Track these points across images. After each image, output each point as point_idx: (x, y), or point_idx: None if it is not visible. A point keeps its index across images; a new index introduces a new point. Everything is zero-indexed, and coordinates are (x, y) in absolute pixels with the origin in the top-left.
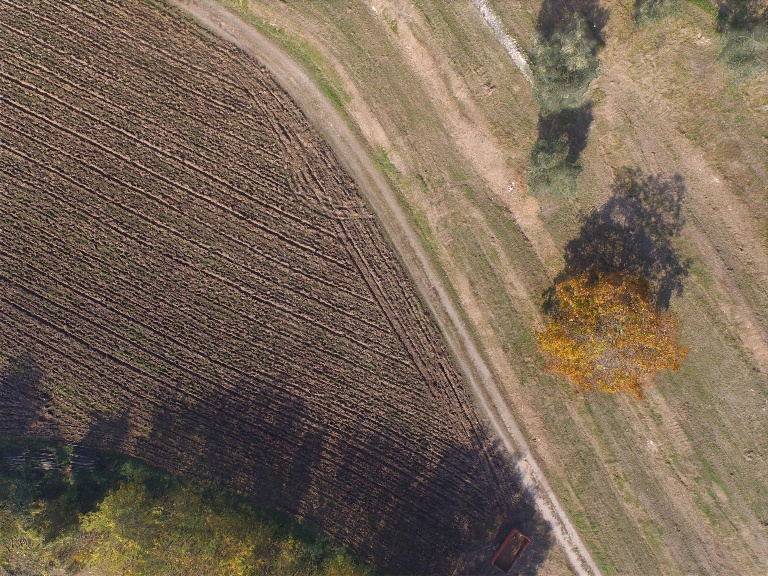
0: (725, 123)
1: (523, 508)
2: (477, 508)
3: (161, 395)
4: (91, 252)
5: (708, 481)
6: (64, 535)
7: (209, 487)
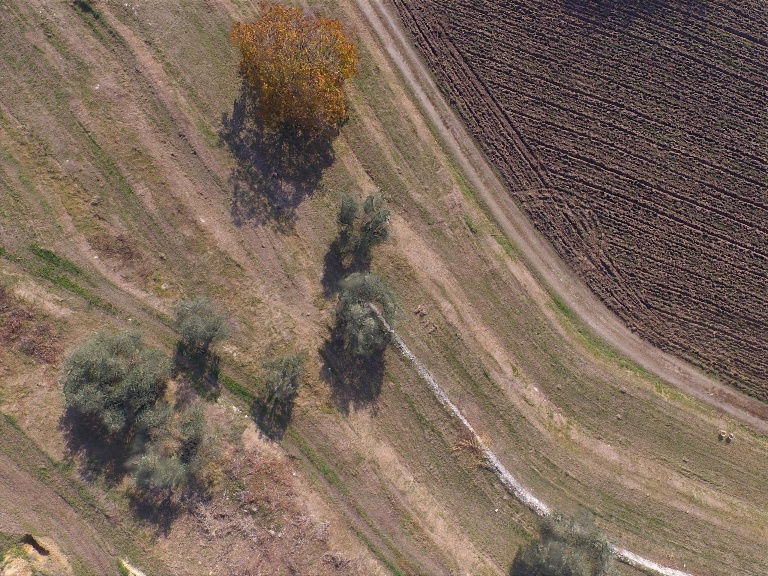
0: (202, 271)
1: None
2: None
3: (702, 8)
4: None
5: None
6: None
7: None
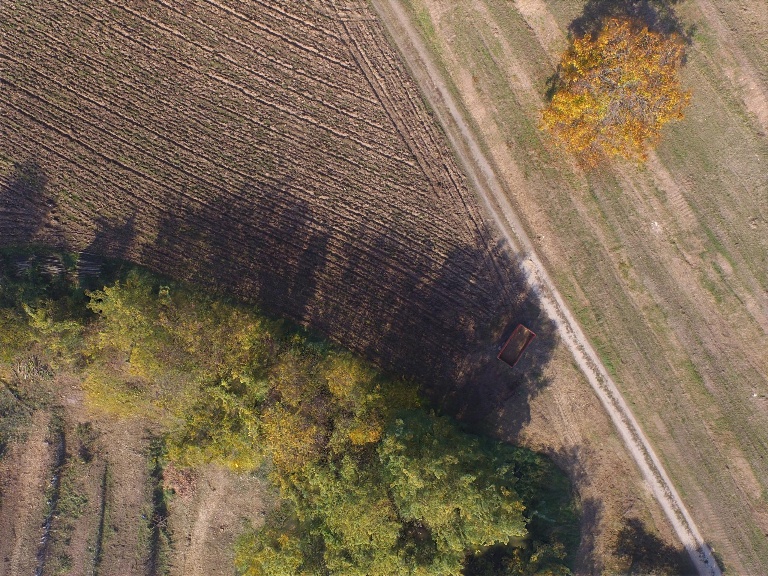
0: None
1: (528, 308)
2: (482, 308)
3: (166, 200)
4: (95, 56)
5: (713, 254)
6: (72, 319)
7: (215, 294)
